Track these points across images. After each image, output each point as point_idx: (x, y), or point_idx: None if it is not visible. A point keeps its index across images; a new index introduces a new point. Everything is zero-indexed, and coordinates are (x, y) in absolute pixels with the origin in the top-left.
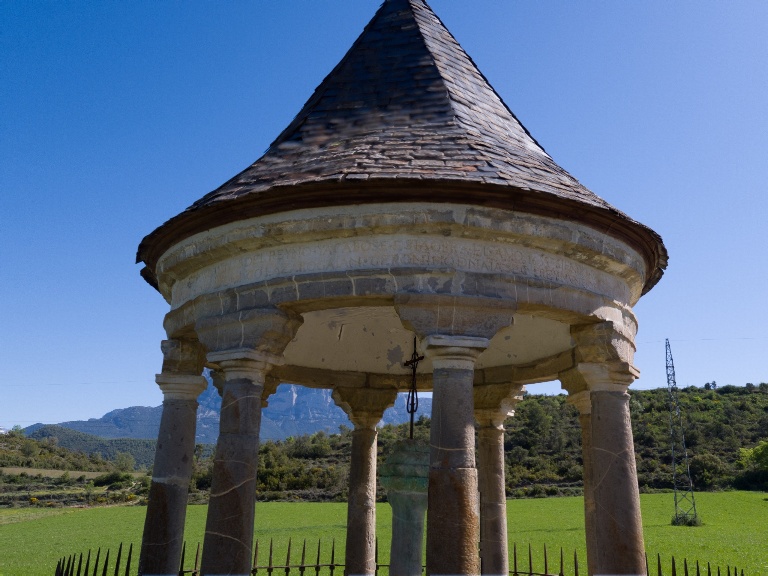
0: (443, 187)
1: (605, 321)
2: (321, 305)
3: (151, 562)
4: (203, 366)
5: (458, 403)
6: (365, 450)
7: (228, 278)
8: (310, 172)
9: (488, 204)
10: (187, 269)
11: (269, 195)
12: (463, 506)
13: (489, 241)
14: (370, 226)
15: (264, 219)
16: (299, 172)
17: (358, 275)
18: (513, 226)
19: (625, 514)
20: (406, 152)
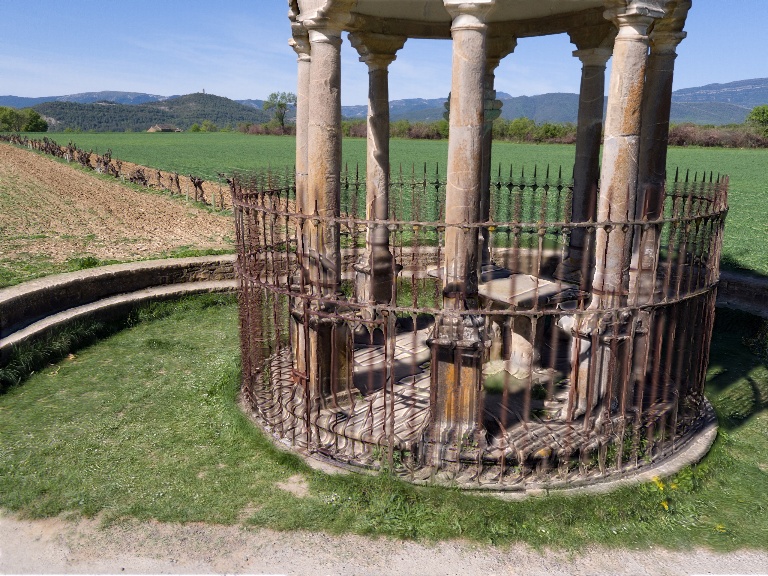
0: None
1: None
2: (441, 38)
3: None
4: None
5: None
6: None
7: None
8: None
9: None
10: None
11: None
12: None
13: None
14: None
15: None
16: None
17: None
18: None
19: None
20: None
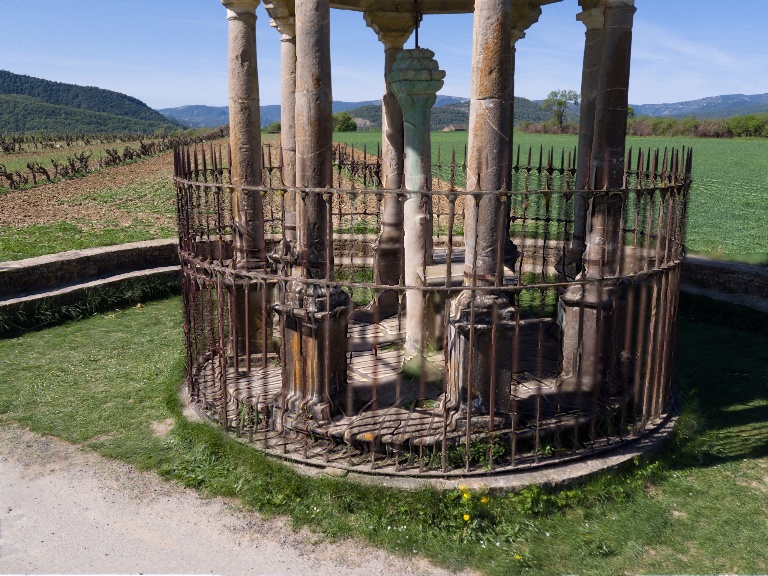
0: None
1: None
2: (462, 12)
3: None
4: None
5: None
6: None
7: None
8: None
9: None
10: None
11: None
12: None
13: None
14: None
15: None
16: None
17: None
18: None
19: None
20: None
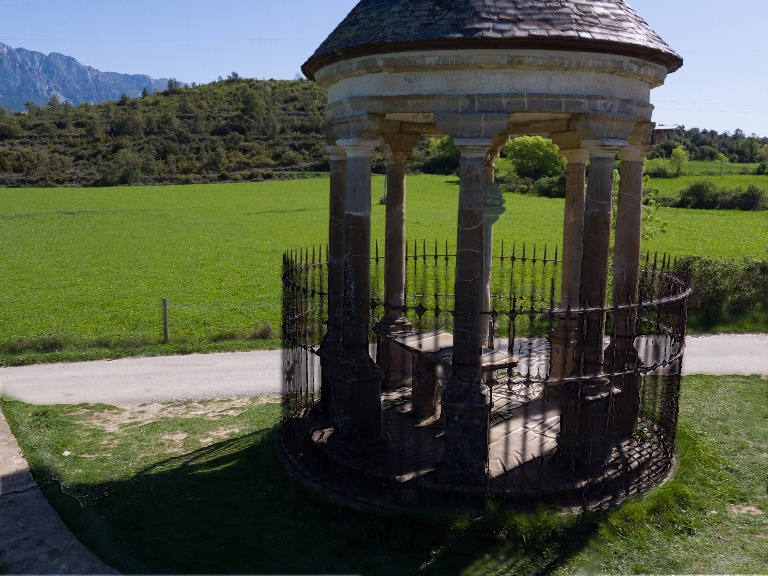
0: (625, 46)
1: (651, 122)
2: None
3: (359, 266)
4: None
5: (610, 177)
6: (400, 180)
7: (464, 85)
8: (543, 21)
9: (640, 57)
10: (413, 69)
11: (522, 37)
12: (608, 232)
13: (629, 78)
14: (579, 66)
15: (510, 52)
16: (534, 19)
17: (567, 98)
18: (645, 70)
19: (636, 228)
20: (591, 9)
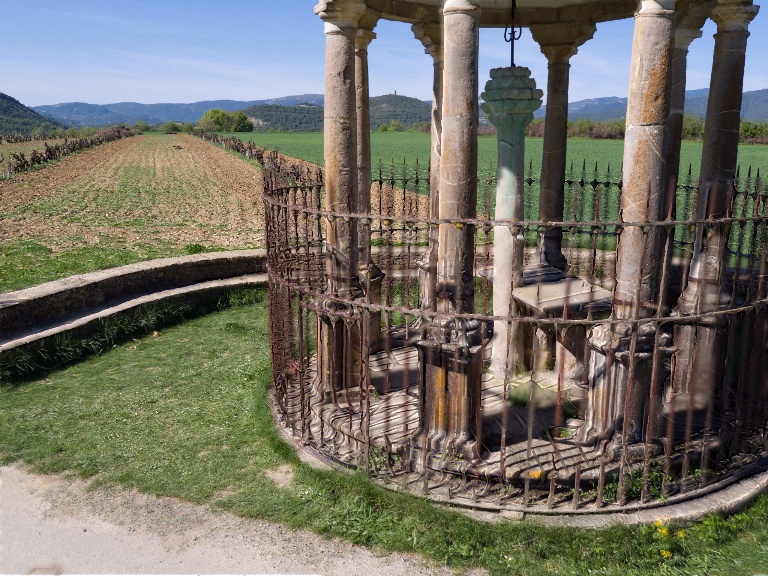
0: None
1: None
2: None
3: None
4: (686, 11)
5: None
6: None
7: None
8: None
9: None
10: None
11: None
12: None
13: None
14: None
15: None
16: None
17: None
18: None
19: None
20: None
